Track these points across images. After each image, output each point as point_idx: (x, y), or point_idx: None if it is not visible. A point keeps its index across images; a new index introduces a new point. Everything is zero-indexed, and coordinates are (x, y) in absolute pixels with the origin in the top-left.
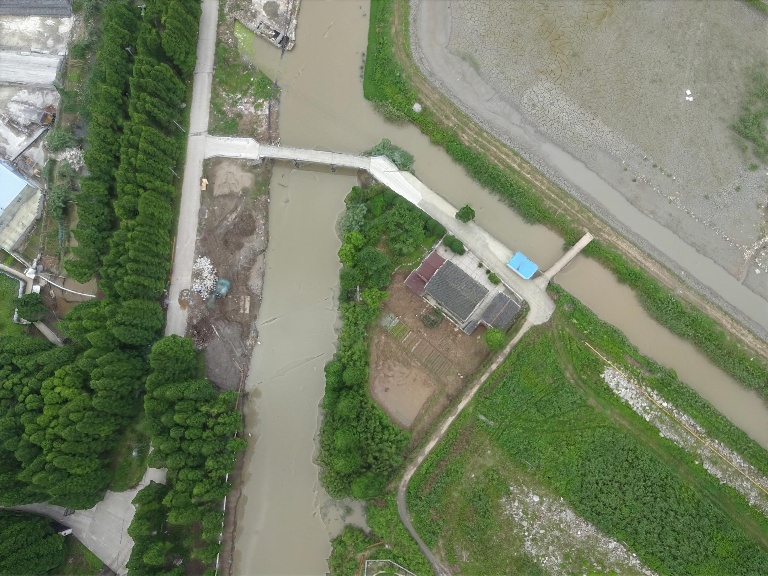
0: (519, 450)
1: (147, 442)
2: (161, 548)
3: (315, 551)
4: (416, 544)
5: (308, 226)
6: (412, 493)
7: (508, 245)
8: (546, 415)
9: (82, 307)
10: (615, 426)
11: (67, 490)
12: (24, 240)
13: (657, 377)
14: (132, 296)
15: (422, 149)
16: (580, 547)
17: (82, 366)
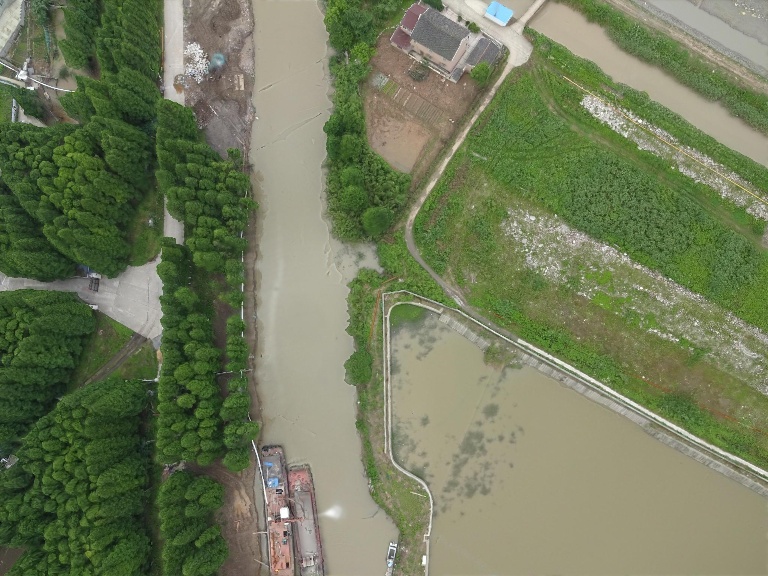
0: (513, 177)
1: (161, 217)
2: (189, 291)
3: (333, 303)
4: (427, 273)
5: (291, 11)
6: (419, 228)
7: (483, 1)
8: (534, 144)
9: (83, 77)
10: (597, 146)
11: (92, 243)
12: (11, 48)
13: (631, 98)
14: (130, 68)
15: None
16: (576, 254)
17: (91, 128)
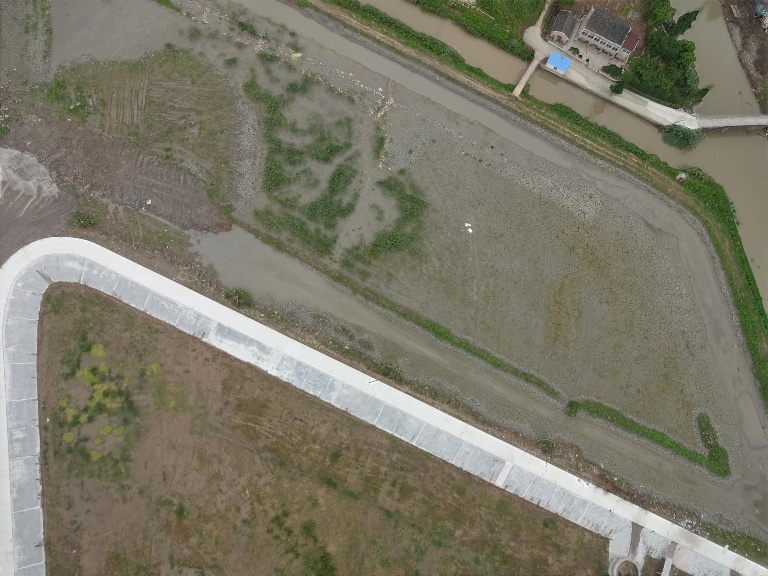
0: None
1: None
2: None
3: None
4: None
5: (712, 86)
6: None
7: None
8: None
9: None
10: None
11: None
12: None
13: (437, 2)
14: None
15: (660, 150)
16: None
17: None
